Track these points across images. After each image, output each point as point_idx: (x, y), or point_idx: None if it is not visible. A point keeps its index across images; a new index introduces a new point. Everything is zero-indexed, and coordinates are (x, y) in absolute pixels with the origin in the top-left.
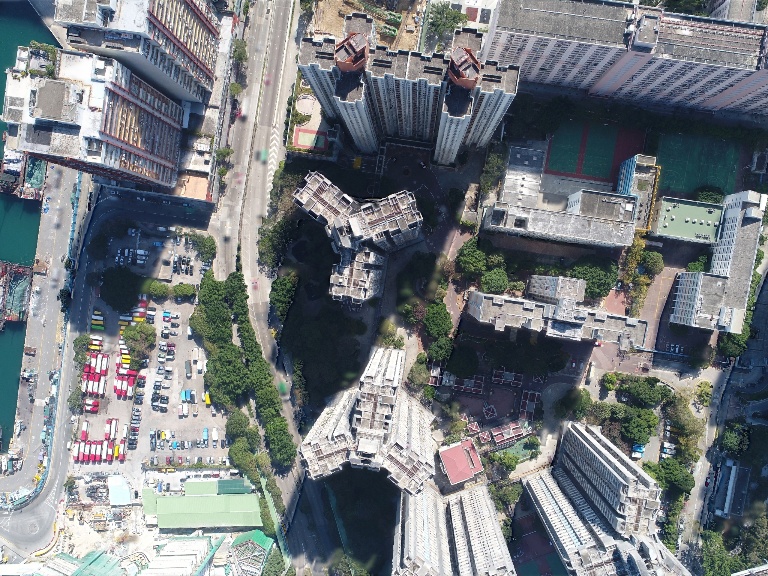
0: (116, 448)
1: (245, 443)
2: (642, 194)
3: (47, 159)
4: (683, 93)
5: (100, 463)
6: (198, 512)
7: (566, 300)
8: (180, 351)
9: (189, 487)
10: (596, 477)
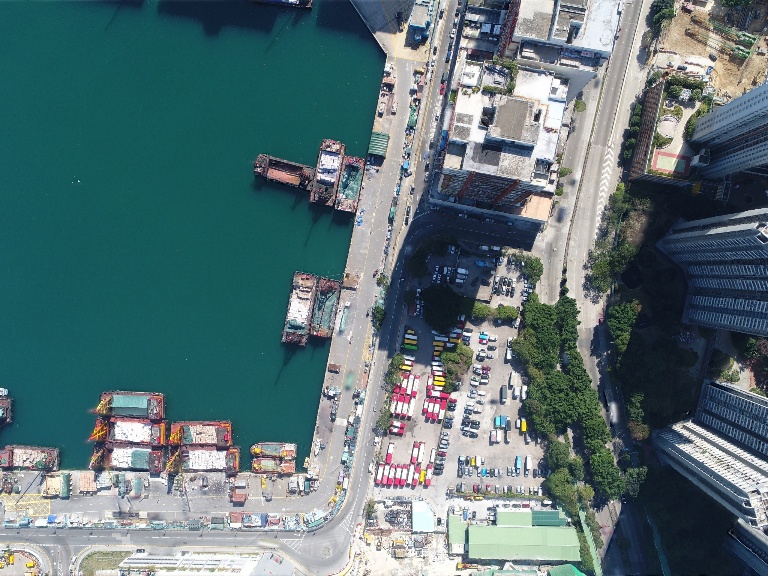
0: (423, 473)
1: (567, 474)
2: None
3: None
4: None
5: (402, 487)
6: (513, 544)
7: None
8: (495, 375)
9: (502, 517)
10: None
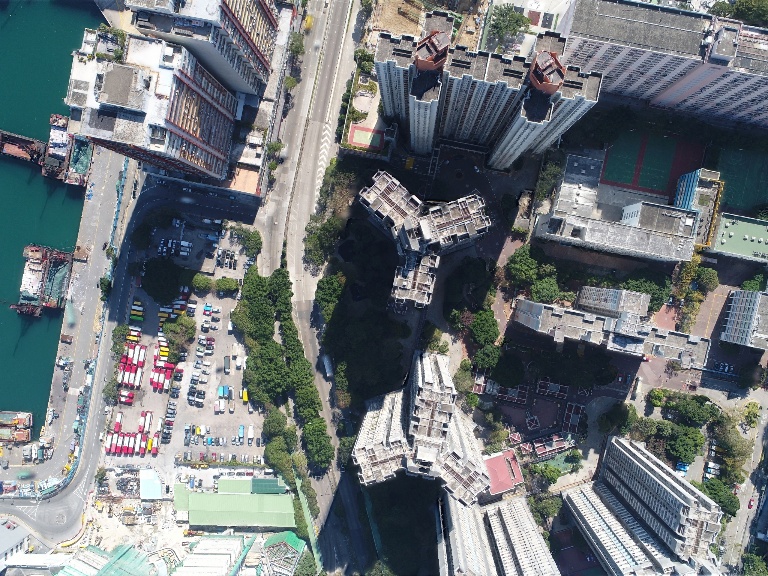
0: (149, 441)
1: (282, 443)
2: (703, 209)
3: (107, 145)
4: (749, 108)
5: (132, 456)
6: (231, 510)
7: (630, 314)
8: (219, 346)
9: (222, 484)
10: (648, 496)
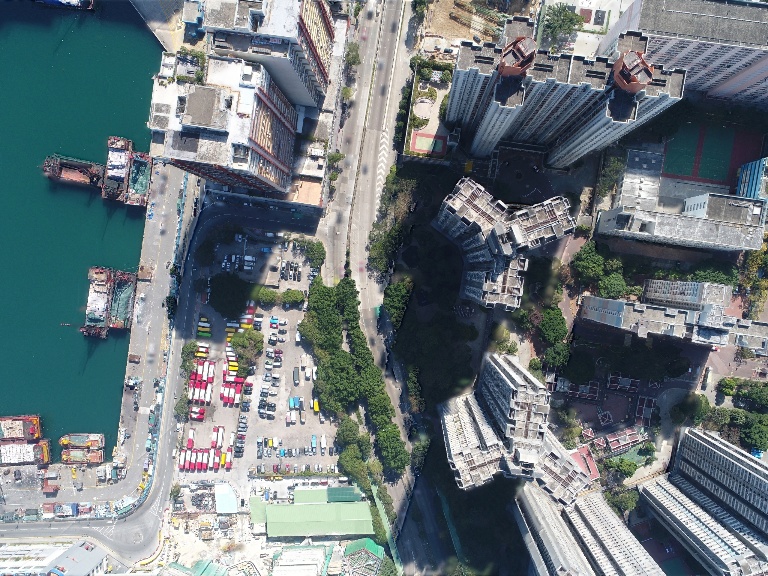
0: (223, 456)
1: (356, 451)
2: None
3: (187, 166)
4: None
5: (206, 471)
6: (309, 520)
7: (715, 306)
8: (287, 358)
9: (299, 495)
10: (738, 485)
